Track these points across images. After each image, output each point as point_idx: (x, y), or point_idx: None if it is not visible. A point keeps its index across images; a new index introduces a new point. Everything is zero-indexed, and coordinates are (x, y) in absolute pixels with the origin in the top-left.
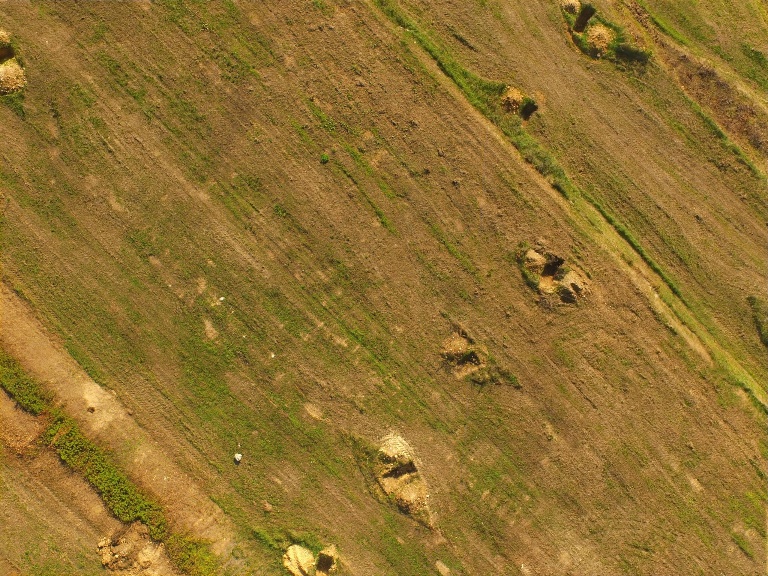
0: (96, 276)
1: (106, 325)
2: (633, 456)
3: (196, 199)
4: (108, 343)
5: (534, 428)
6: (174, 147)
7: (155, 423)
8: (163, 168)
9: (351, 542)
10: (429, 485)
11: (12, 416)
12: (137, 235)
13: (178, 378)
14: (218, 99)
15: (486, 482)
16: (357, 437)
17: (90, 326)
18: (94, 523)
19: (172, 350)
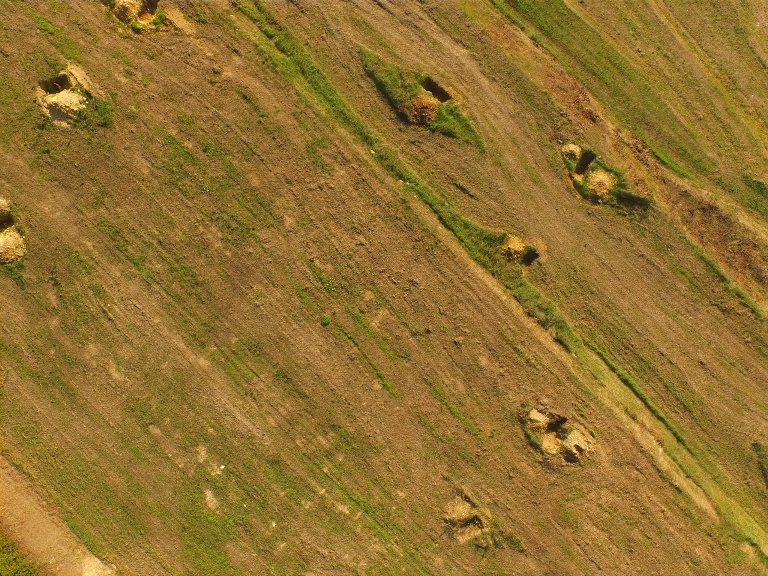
0: (96, 447)
1: (106, 497)
2: None
3: (196, 365)
4: (108, 515)
5: None
6: (174, 313)
7: None
8: (163, 335)
9: None
10: None
11: None
12: (137, 404)
13: (178, 550)
14: (218, 262)
15: None
16: None
17: (90, 498)
18: None
19: (172, 521)
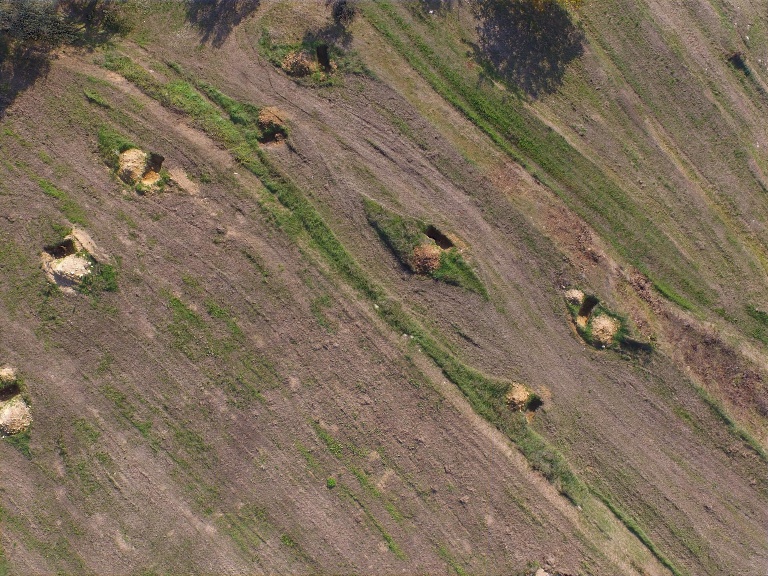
0: None
1: None
2: None
3: (203, 533)
4: None
5: None
6: (180, 479)
7: None
8: (169, 502)
9: None
10: None
11: None
12: (144, 574)
13: None
14: (224, 426)
15: None
16: None
17: None
18: None
19: None
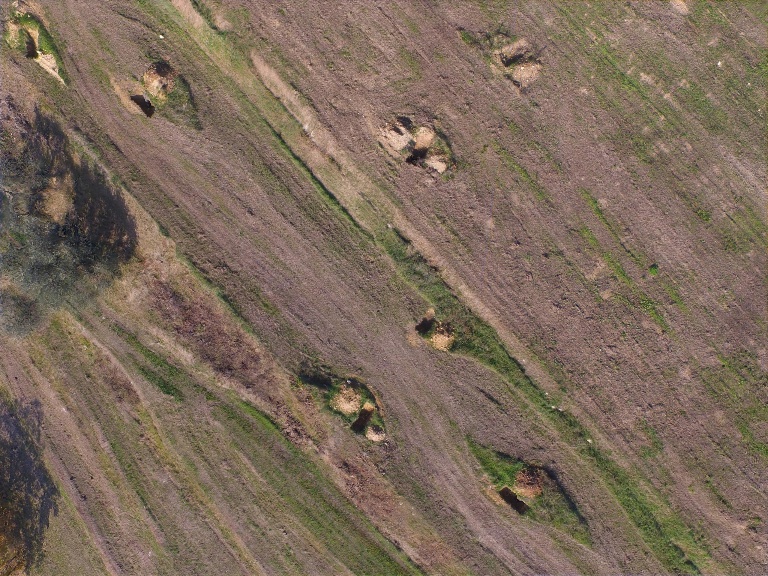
0: None
1: None
2: None
3: None
4: None
5: None
6: None
7: None
8: None
9: None
10: None
11: None
12: None
13: None
14: (763, 334)
15: None
16: None
17: None
18: None
19: None
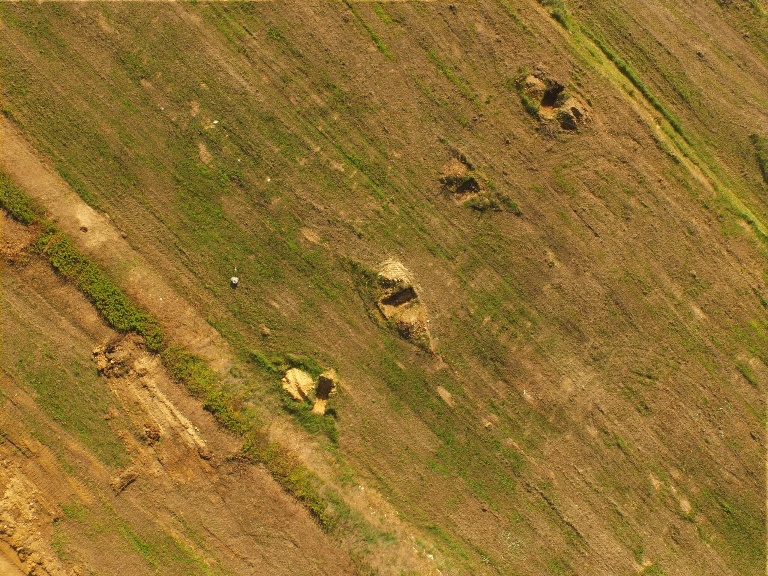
0: (86, 98)
1: (98, 148)
2: (636, 284)
3: (188, 21)
4: (100, 166)
5: (535, 255)
6: None
7: (150, 247)
8: None
9: (351, 367)
10: (429, 311)
11: (3, 224)
12: (128, 57)
13: (172, 202)
14: None
15: (487, 308)
16: (355, 261)
17: (81, 149)
18: (89, 331)
19: (166, 174)
